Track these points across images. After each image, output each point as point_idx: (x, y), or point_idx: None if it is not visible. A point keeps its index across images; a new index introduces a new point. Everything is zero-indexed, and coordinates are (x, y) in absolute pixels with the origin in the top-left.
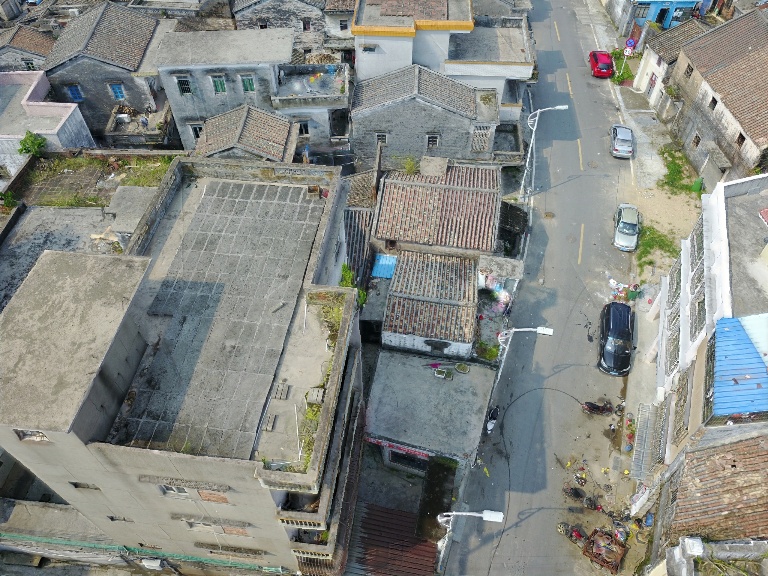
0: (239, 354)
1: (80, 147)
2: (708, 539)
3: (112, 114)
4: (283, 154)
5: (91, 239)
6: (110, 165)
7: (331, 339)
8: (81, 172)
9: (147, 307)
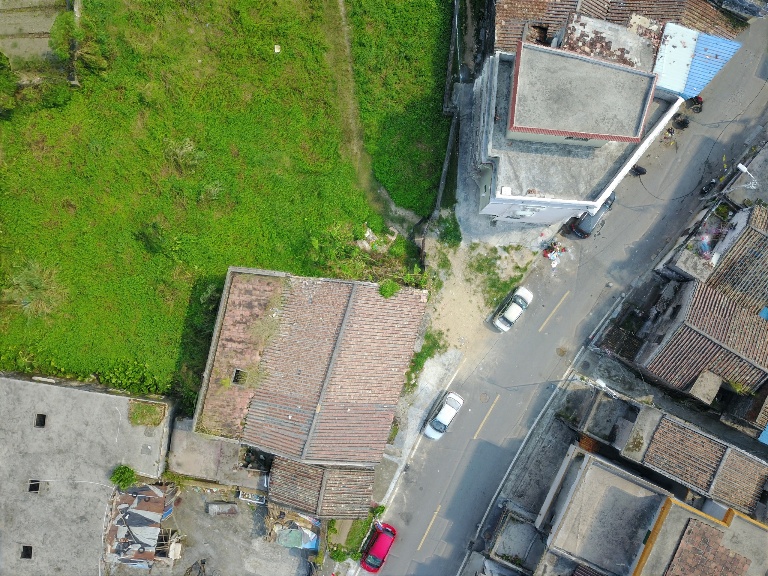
0: None
1: None
2: (731, 20)
3: None
4: None
5: None
6: None
7: None
8: None
9: None
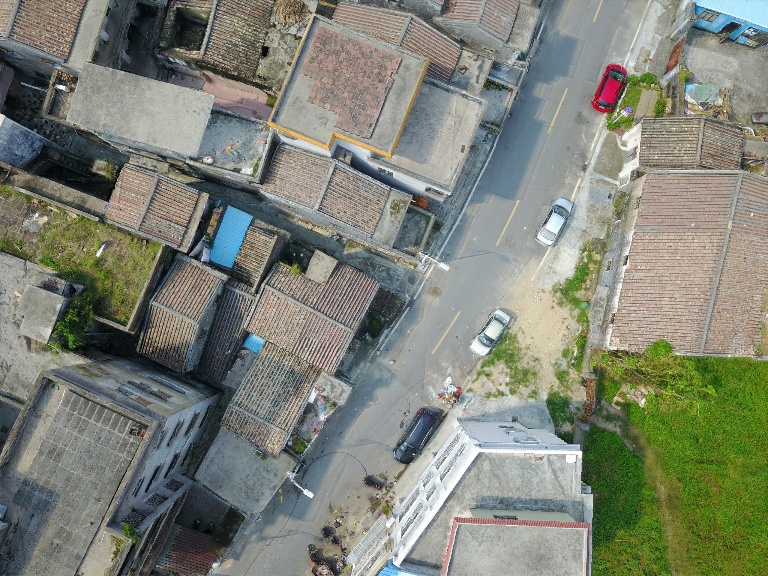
0: (60, 552)
1: (10, 166)
2: None
3: (50, 85)
4: (183, 237)
5: (15, 296)
6: (35, 203)
7: (115, 554)
8: (11, 203)
9: (14, 494)
